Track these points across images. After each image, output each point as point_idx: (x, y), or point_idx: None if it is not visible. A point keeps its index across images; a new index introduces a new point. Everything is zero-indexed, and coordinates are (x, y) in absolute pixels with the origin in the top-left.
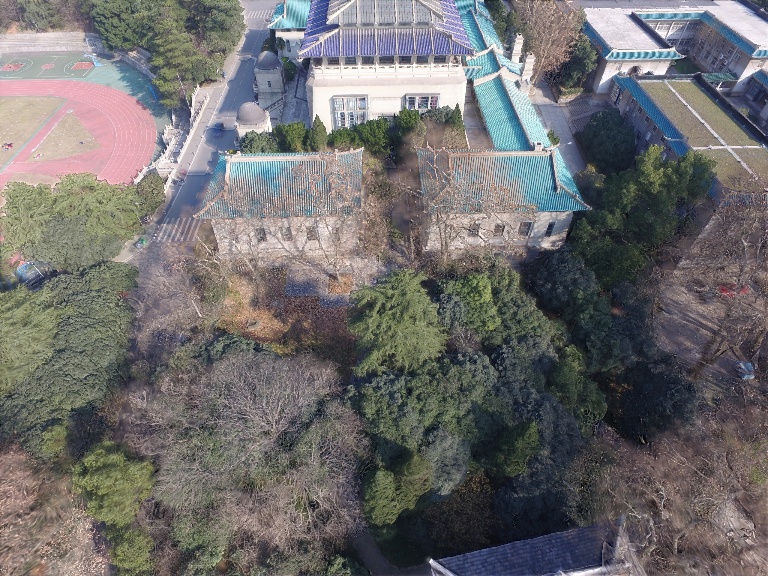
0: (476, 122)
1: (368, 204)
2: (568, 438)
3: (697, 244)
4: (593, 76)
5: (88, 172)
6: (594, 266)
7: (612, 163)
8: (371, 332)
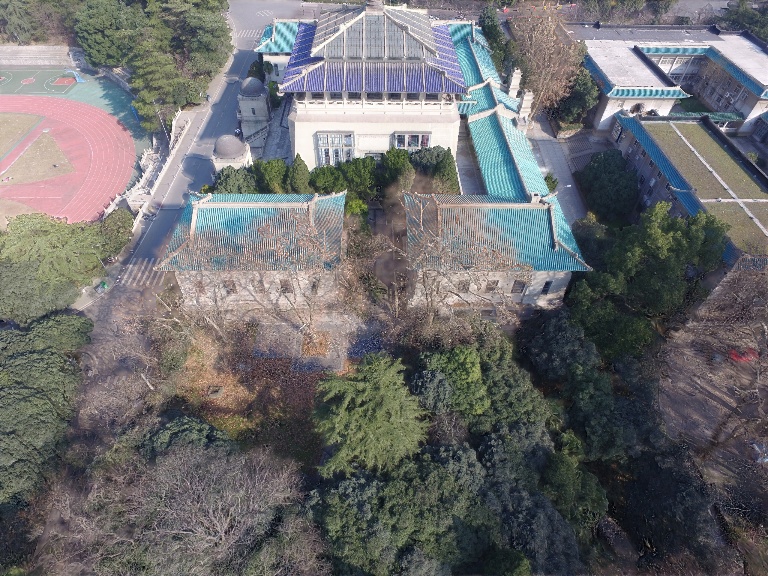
0: (470, 161)
1: (347, 259)
2: (564, 559)
3: (705, 306)
4: (594, 112)
5: None
6: (595, 336)
7: (613, 209)
8: (338, 433)
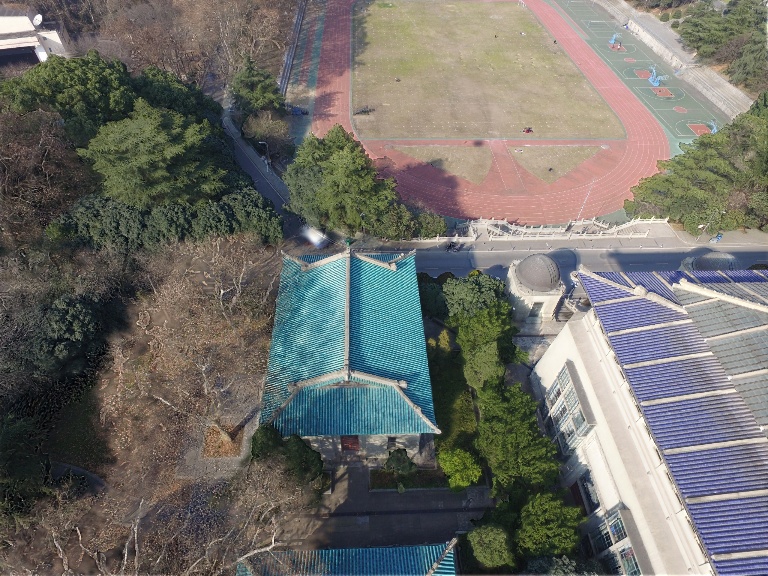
0: None
1: None
2: None
3: None
4: None
5: (363, 163)
6: None
7: None
8: None
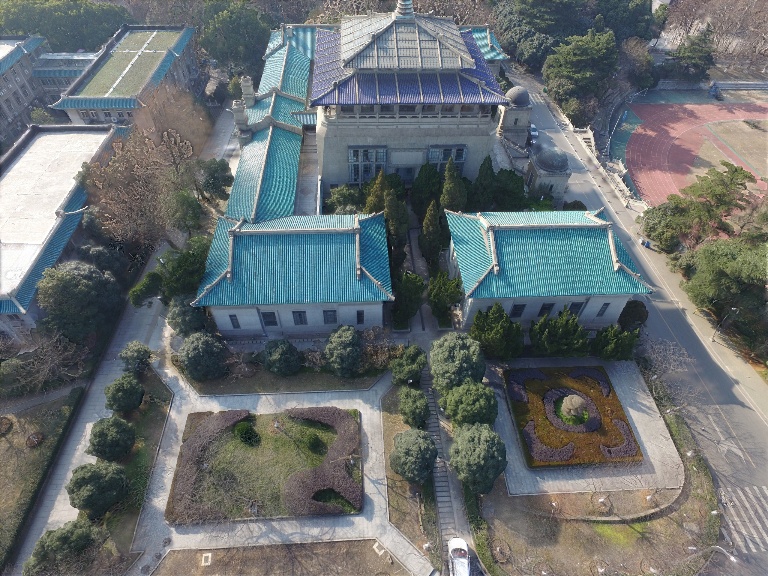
0: None
1: None
2: (323, 1)
3: None
4: None
5: (580, 44)
6: None
7: None
8: None
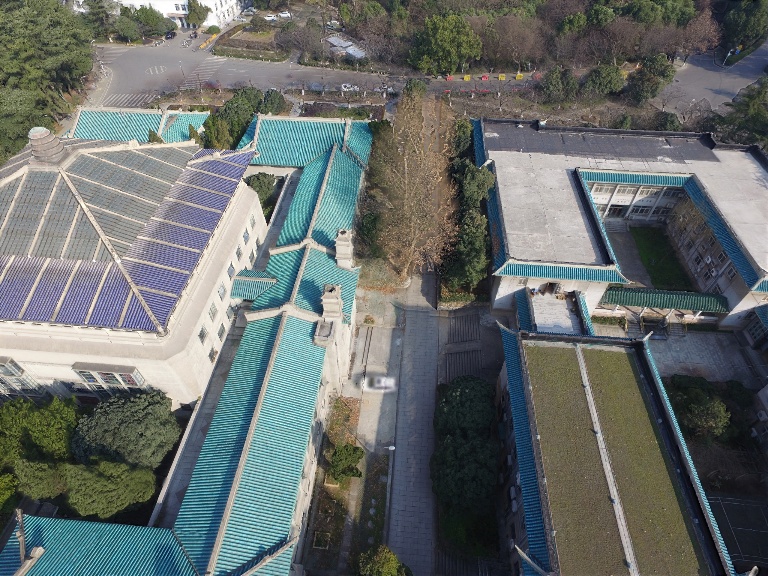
0: None
1: None
2: None
3: None
4: (493, 276)
5: None
6: None
7: (458, 503)
8: None
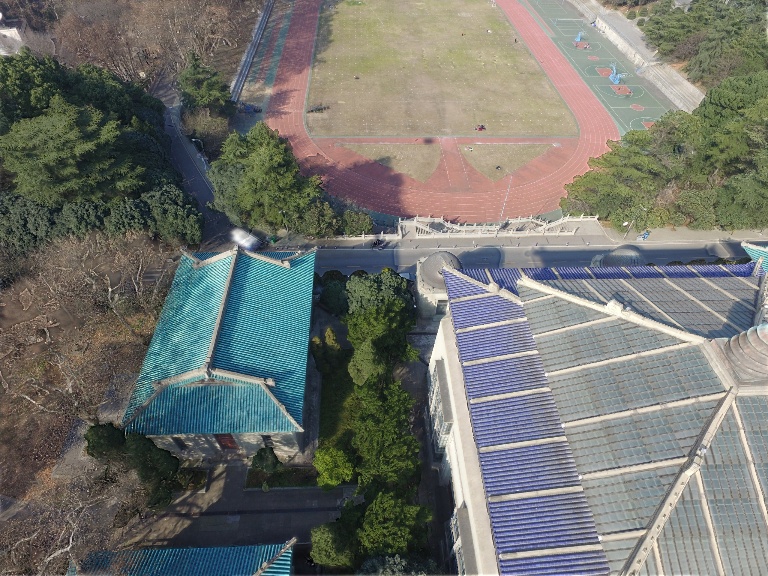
0: None
1: None
2: None
3: None
4: None
5: (281, 160)
6: None
7: None
8: None
